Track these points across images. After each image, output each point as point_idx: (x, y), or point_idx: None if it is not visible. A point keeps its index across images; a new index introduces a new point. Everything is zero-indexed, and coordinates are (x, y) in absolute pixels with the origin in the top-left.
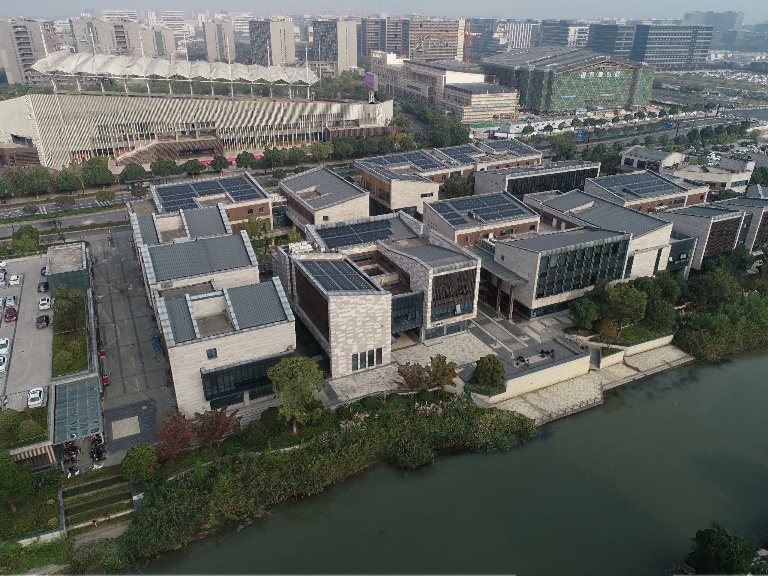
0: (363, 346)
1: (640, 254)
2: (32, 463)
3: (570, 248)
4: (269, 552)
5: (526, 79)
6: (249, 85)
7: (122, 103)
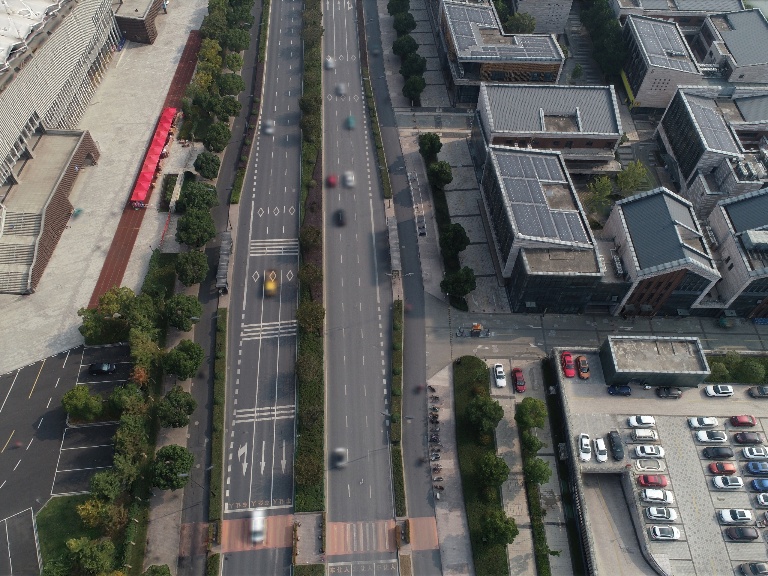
0: None
1: None
2: None
3: None
4: None
5: None
6: None
7: None
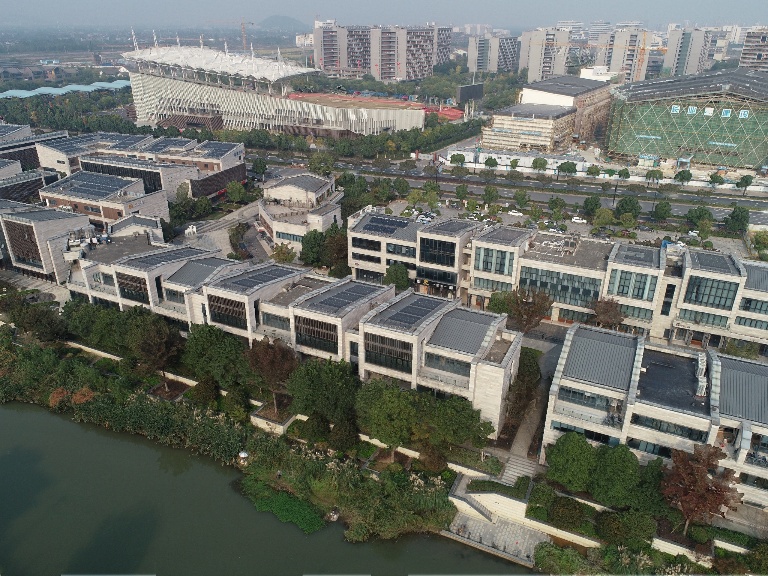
0: None
1: None
2: None
3: None
4: None
5: None
6: None
7: (170, 83)
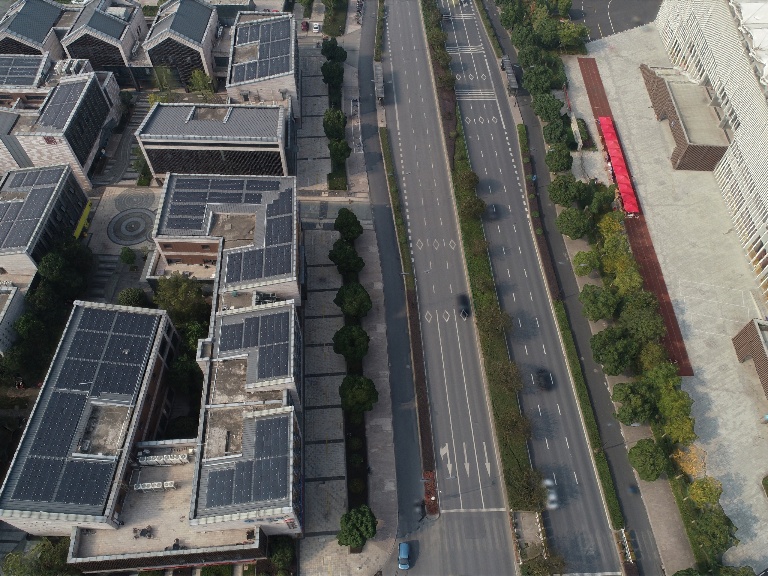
0: None
1: None
2: None
3: None
4: None
5: None
6: None
7: (717, 2)
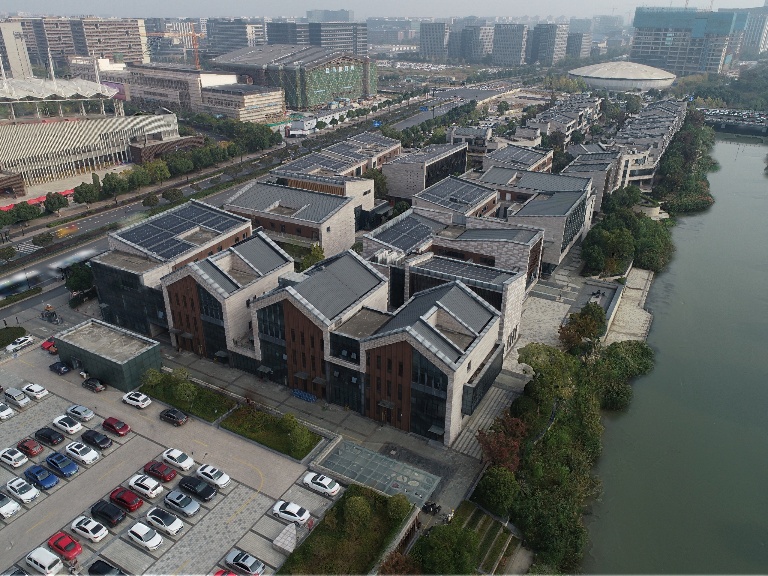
0: (512, 326)
1: (588, 205)
2: (407, 541)
3: (573, 208)
4: (638, 505)
5: (277, 77)
6: (34, 103)
7: None
